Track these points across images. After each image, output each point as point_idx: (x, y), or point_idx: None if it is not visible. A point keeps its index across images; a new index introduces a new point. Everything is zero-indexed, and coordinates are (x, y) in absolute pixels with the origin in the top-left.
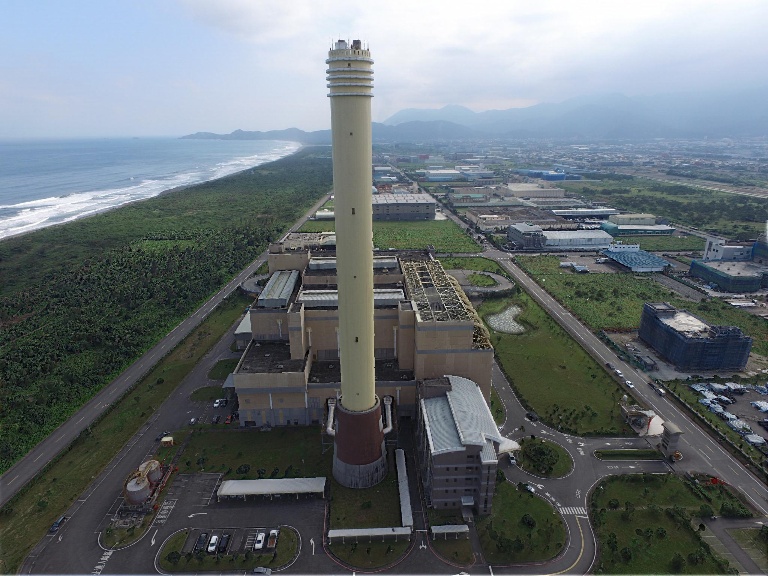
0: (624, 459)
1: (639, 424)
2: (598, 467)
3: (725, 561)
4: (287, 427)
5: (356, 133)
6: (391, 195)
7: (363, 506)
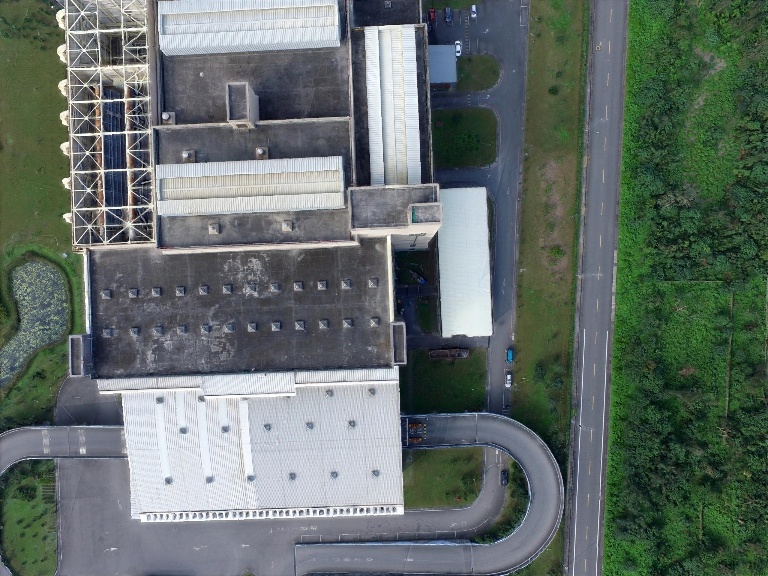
0: None
1: None
2: None
3: None
4: None
5: None
6: None
7: None
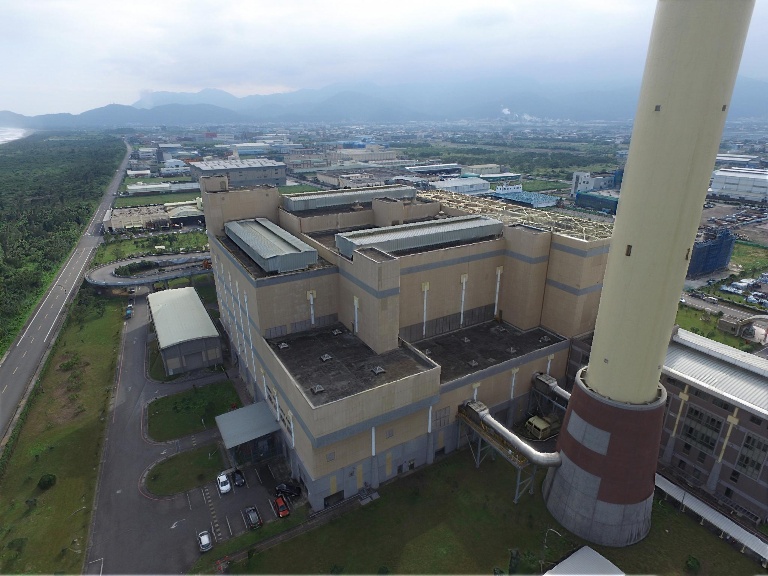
0: None
1: (751, 333)
2: None
3: None
4: (402, 479)
5: None
6: None
7: (692, 570)
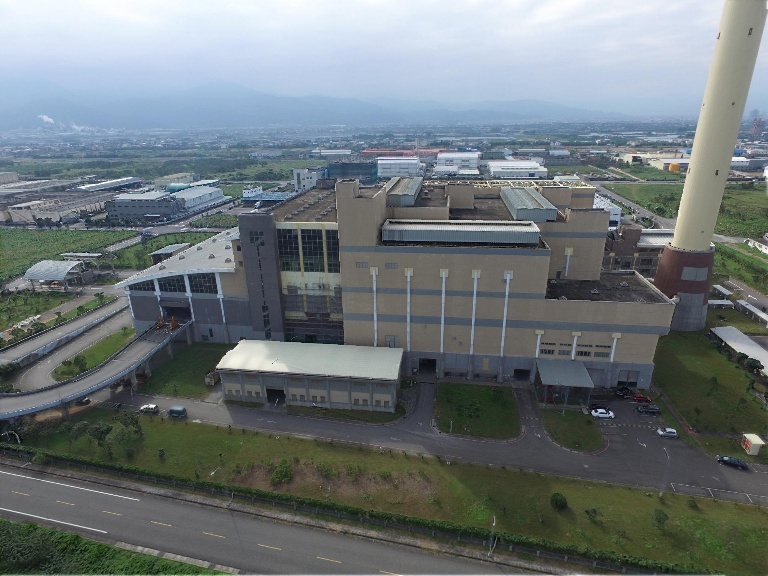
0: None
1: None
2: None
3: None
4: None
5: None
6: None
7: None
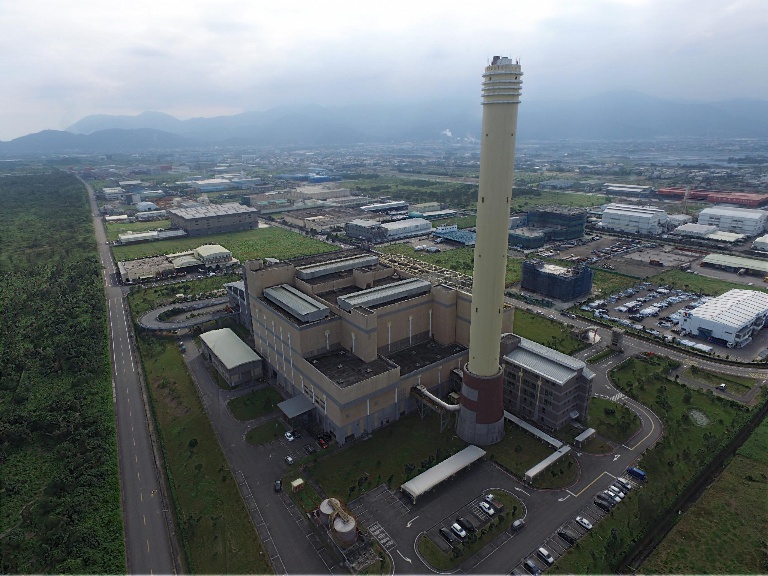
0: (603, 360)
1: (587, 338)
2: (598, 369)
3: (701, 388)
4: (383, 428)
5: (514, 134)
6: (199, 208)
7: (517, 450)
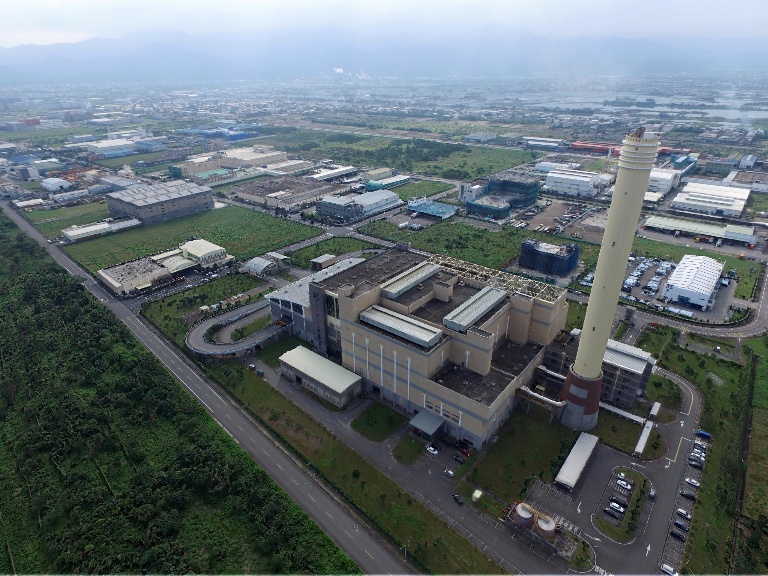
0: (624, 334)
1: None
2: None
3: (707, 353)
4: (502, 428)
5: None
6: (141, 189)
7: (615, 430)
